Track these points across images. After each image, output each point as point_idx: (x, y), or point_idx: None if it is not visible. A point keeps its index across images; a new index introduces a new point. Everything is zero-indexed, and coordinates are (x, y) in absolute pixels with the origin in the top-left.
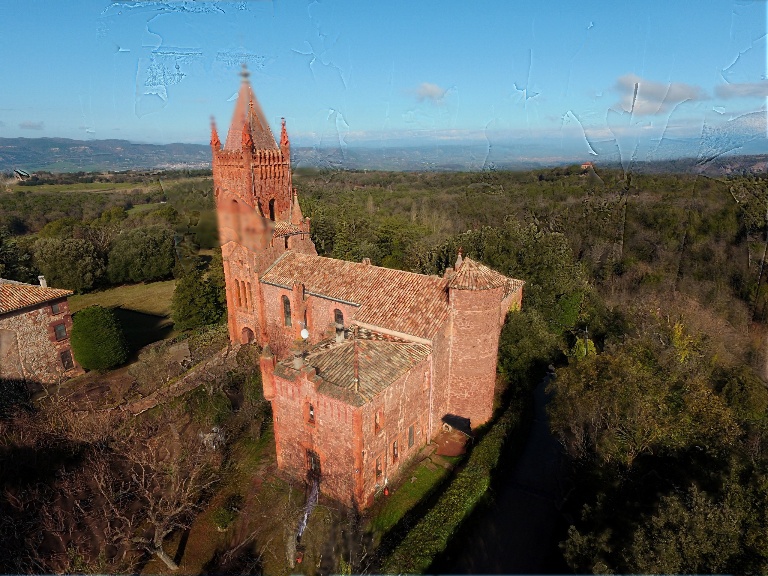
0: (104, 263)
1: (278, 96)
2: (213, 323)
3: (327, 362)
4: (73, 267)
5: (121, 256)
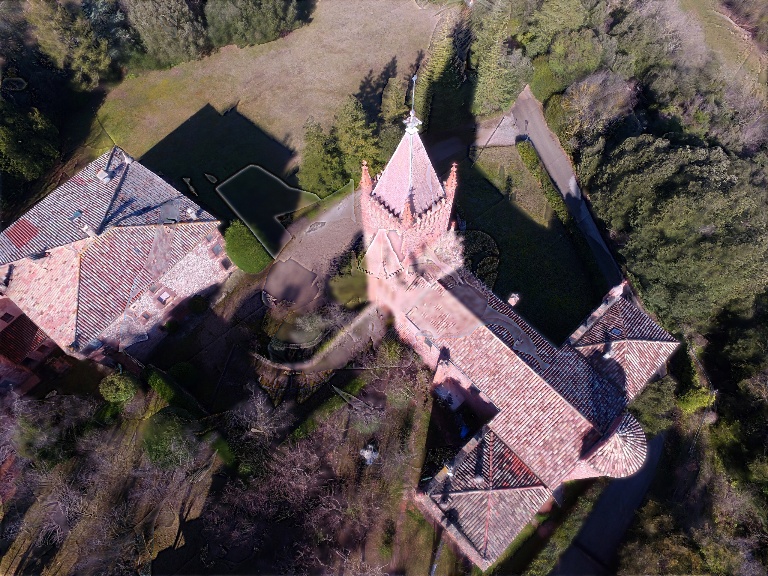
0: (203, 23)
1: None
2: None
3: (465, 508)
4: None
5: (219, 16)
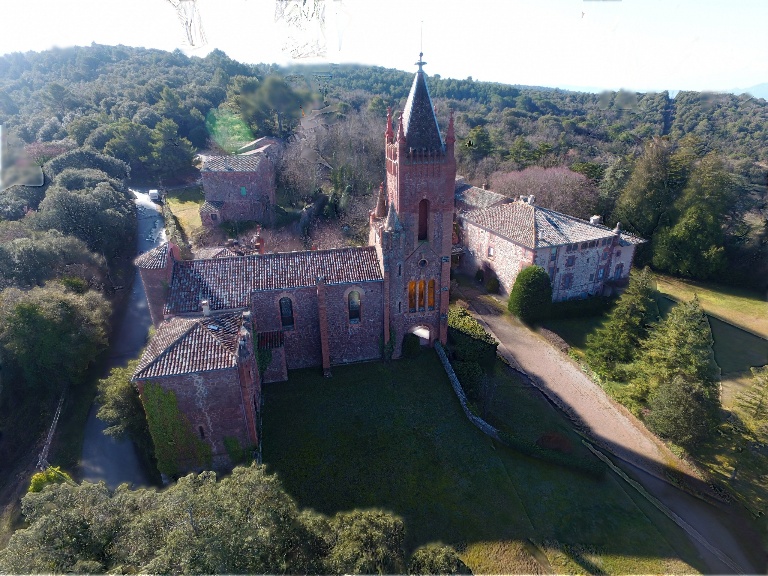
0: None
1: None
2: (601, 377)
3: None
4: None
5: None
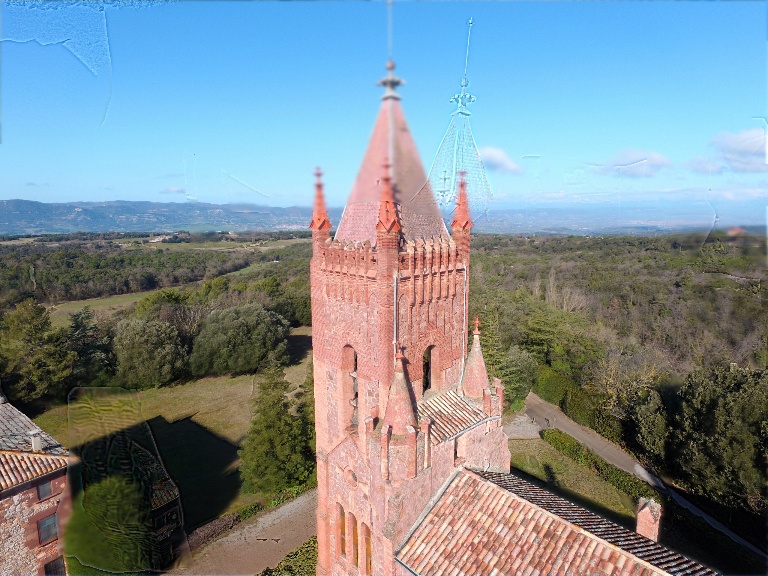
0: (187, 351)
1: (569, 66)
2: (298, 484)
3: None
4: (151, 356)
5: (207, 343)
